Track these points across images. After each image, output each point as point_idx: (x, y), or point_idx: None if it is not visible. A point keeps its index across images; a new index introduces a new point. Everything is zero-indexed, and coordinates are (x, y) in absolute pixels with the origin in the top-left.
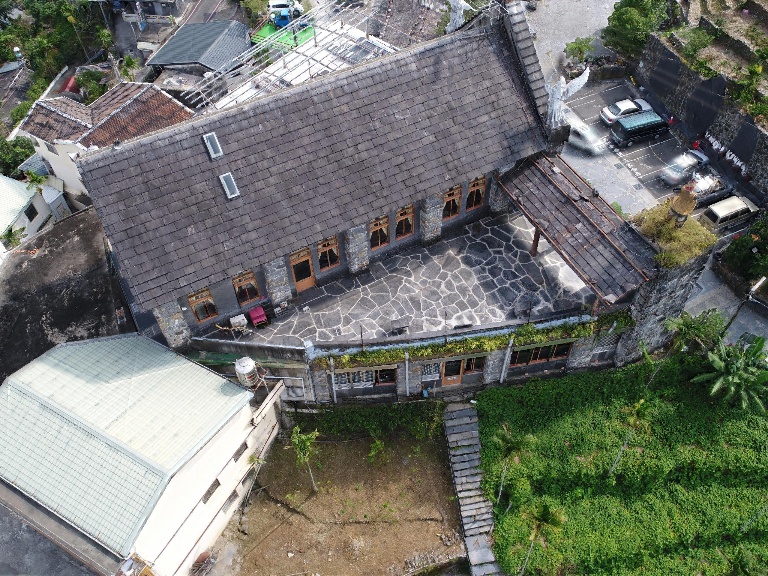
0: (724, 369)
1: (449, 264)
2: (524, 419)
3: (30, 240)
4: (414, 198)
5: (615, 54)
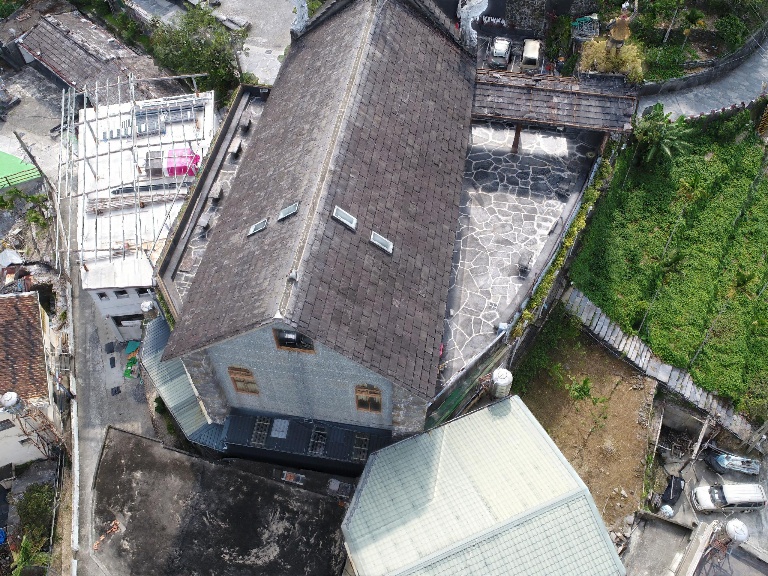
0: (658, 139)
1: (483, 201)
2: (592, 271)
3: (92, 524)
4: (462, 157)
5: (322, 2)
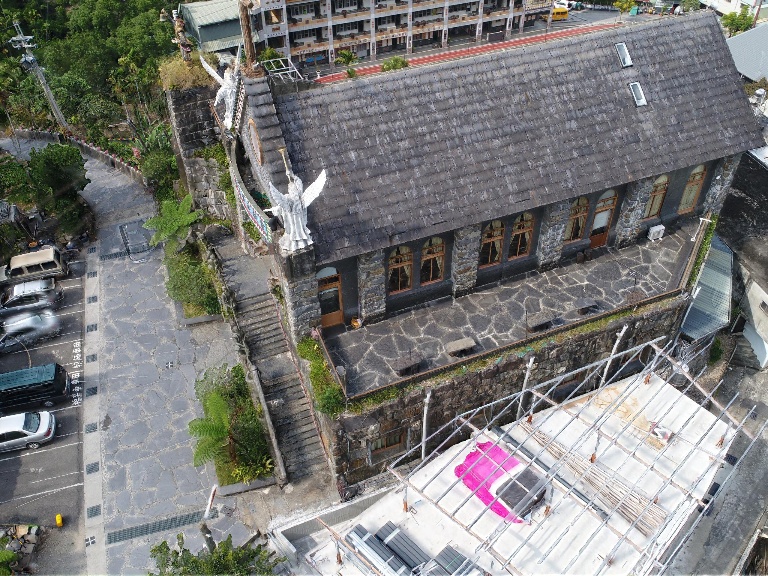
0: None
1: None
2: None
3: None
4: None
5: None
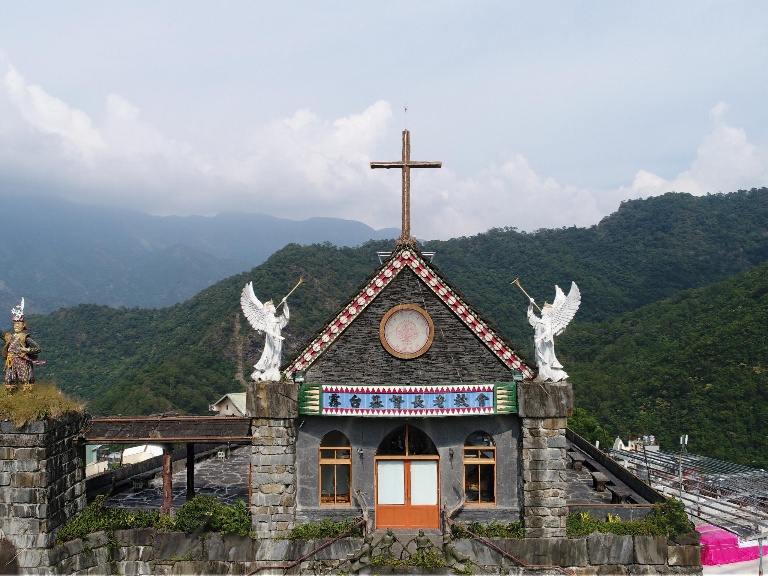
0: None
1: None
2: None
3: None
4: None
5: None
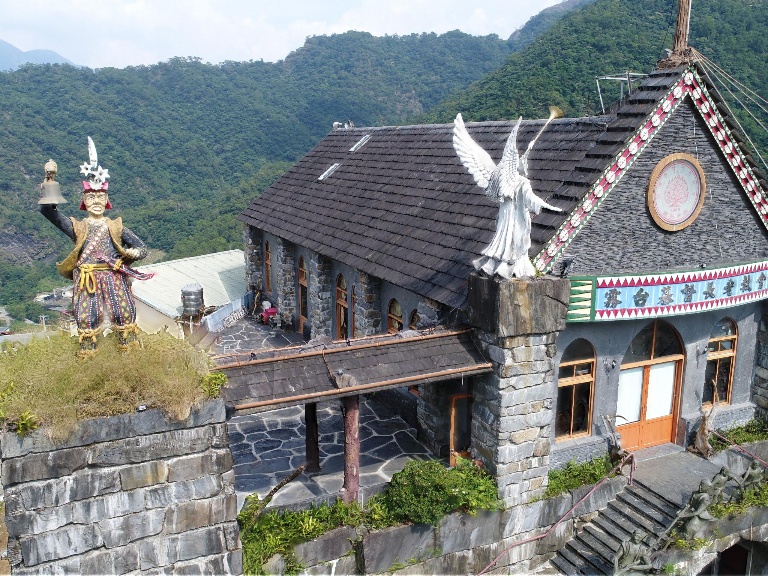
0: None
1: None
2: None
3: None
4: None
5: None
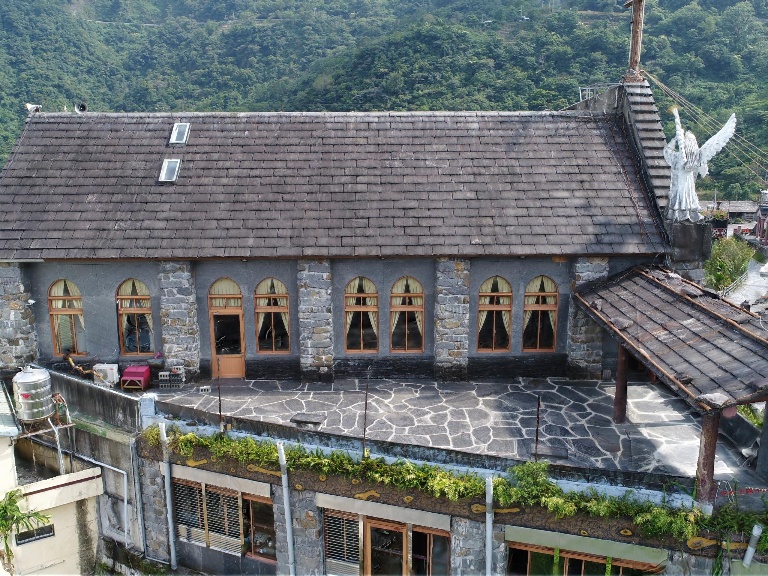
0: None
1: (459, 400)
2: None
3: None
4: (411, 250)
5: None
